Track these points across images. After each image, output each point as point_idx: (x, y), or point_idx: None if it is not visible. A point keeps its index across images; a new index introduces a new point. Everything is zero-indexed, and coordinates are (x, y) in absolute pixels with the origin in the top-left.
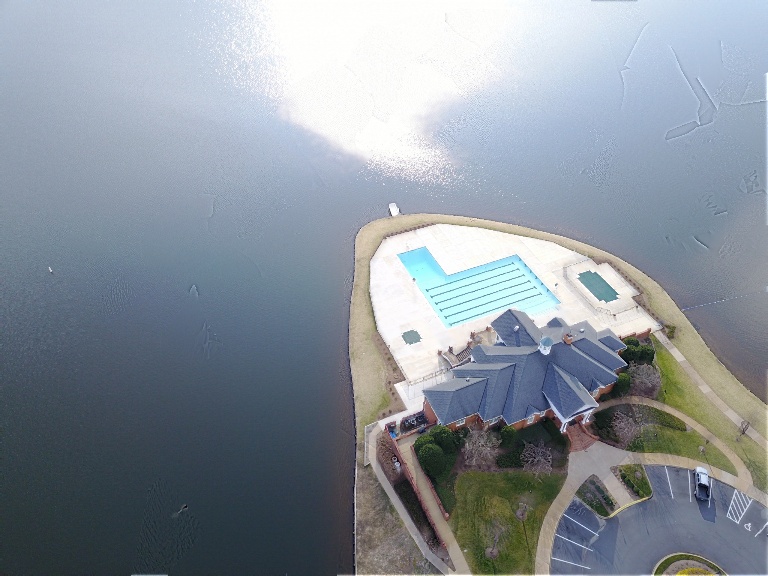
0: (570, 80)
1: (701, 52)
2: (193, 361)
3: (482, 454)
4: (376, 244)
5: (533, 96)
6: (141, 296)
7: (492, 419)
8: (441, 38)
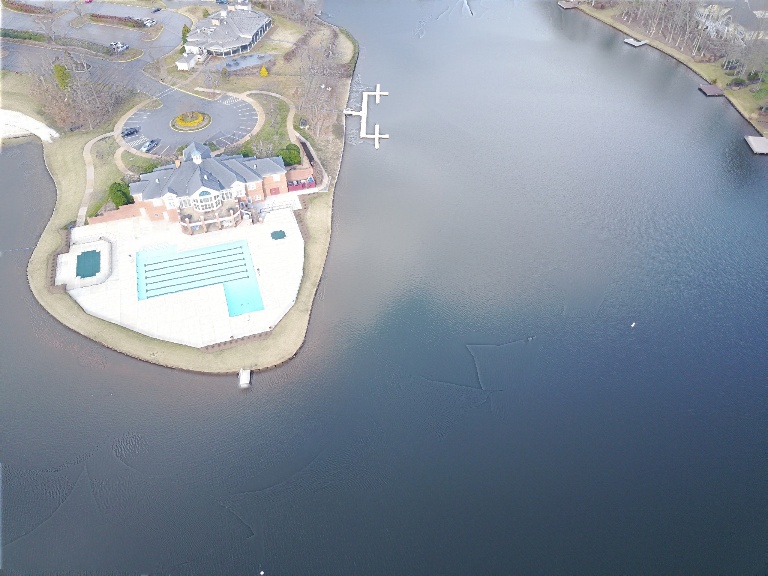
0: None
1: None
2: None
3: None
4: (283, 324)
5: None
6: (529, 317)
7: None
8: None
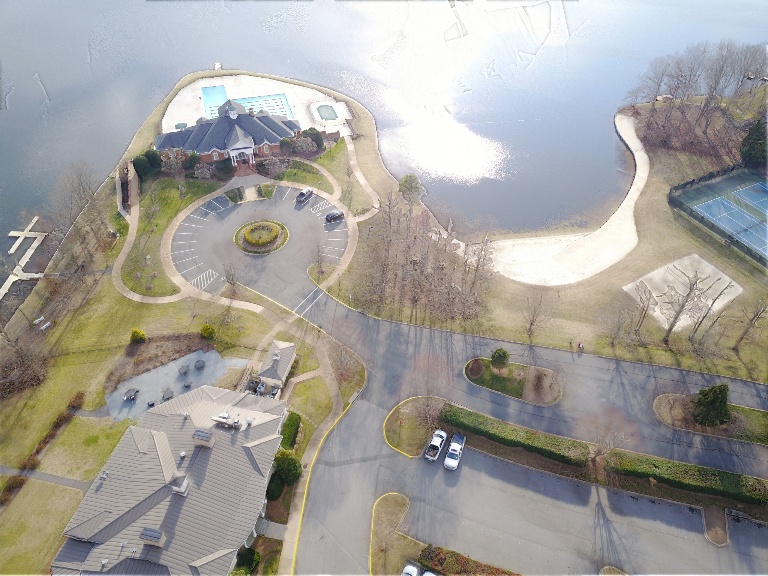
0: None
1: None
2: None
3: (173, 166)
4: (191, 82)
5: None
6: None
7: (188, 151)
8: None
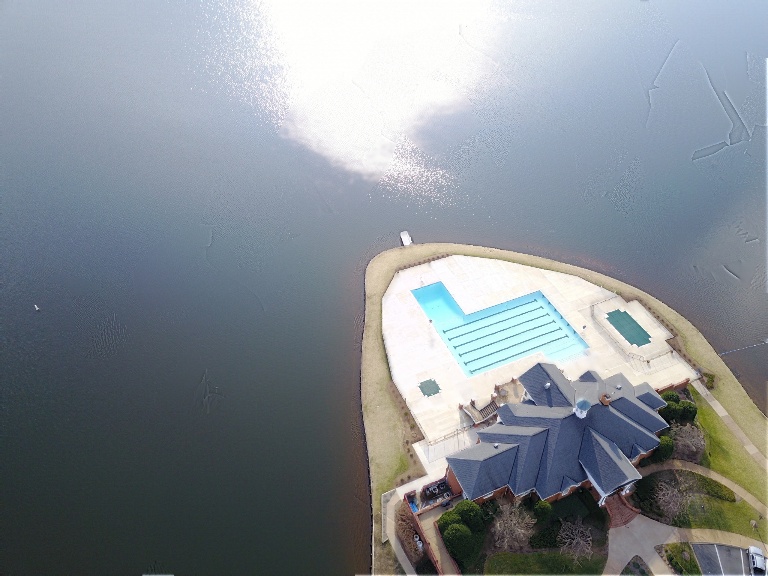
0: (592, 97)
1: (728, 66)
2: (191, 417)
3: (514, 534)
4: (388, 278)
5: (553, 114)
6: (134, 336)
7: (524, 492)
8: (455, 52)
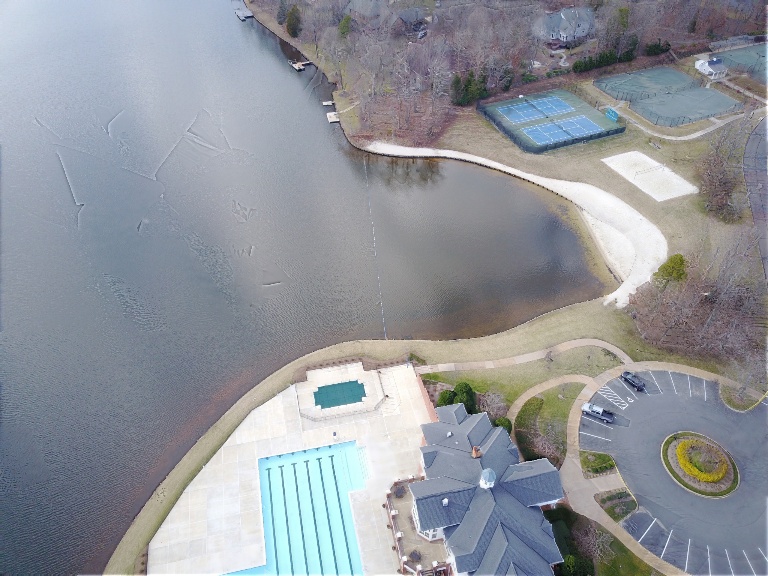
0: (8, 265)
1: (54, 140)
2: None
3: None
4: None
5: (0, 318)
6: None
7: None
8: None
